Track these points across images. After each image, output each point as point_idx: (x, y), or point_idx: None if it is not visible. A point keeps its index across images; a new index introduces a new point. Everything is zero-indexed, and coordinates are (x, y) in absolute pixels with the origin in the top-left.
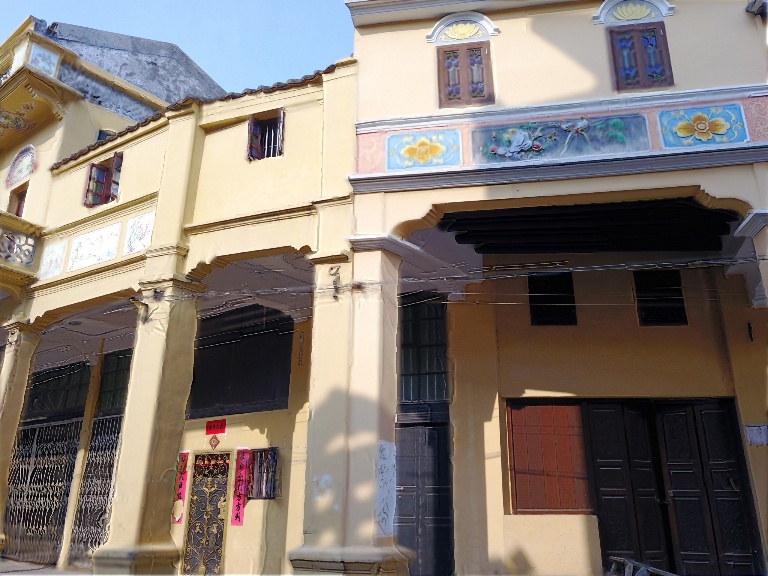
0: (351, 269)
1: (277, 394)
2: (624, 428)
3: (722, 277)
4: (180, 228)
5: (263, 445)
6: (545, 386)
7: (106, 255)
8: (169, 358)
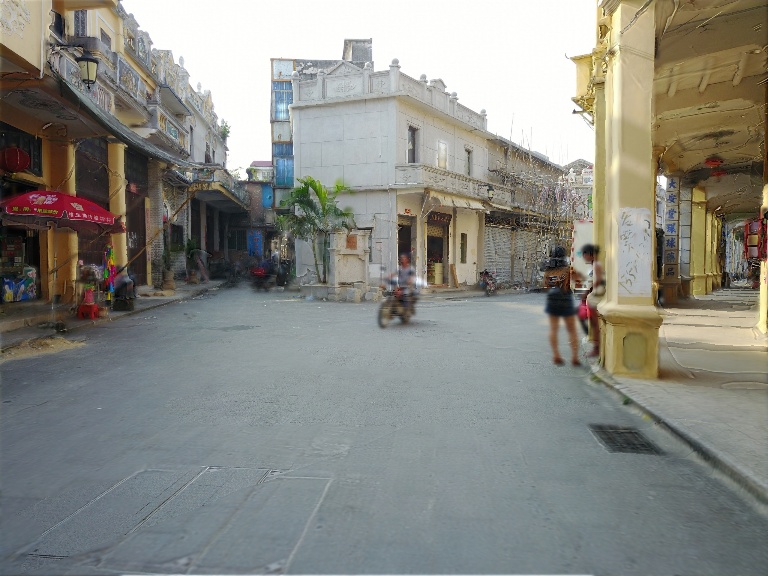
0: (609, 37)
1: None
2: None
3: None
4: (596, 34)
5: None
6: None
7: None
8: (601, 152)
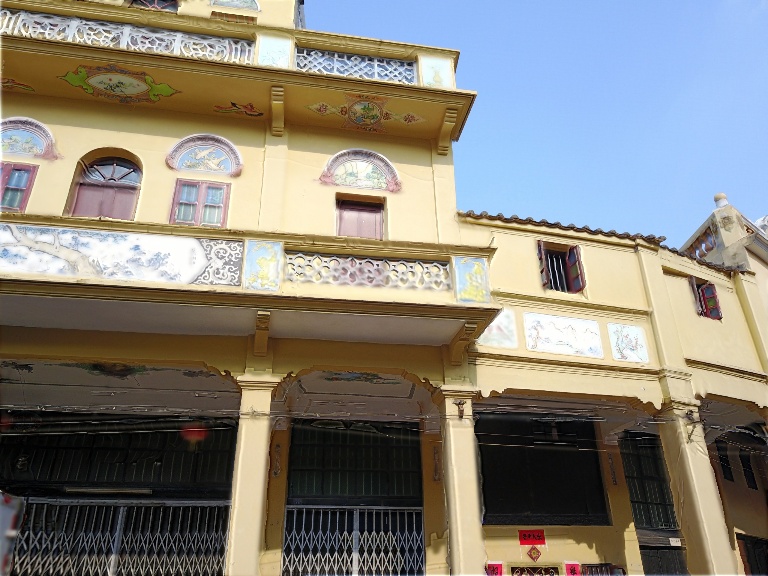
0: None
1: (589, 509)
2: (754, 558)
3: (764, 462)
4: (683, 357)
5: (592, 560)
6: (737, 525)
7: (588, 351)
8: None
